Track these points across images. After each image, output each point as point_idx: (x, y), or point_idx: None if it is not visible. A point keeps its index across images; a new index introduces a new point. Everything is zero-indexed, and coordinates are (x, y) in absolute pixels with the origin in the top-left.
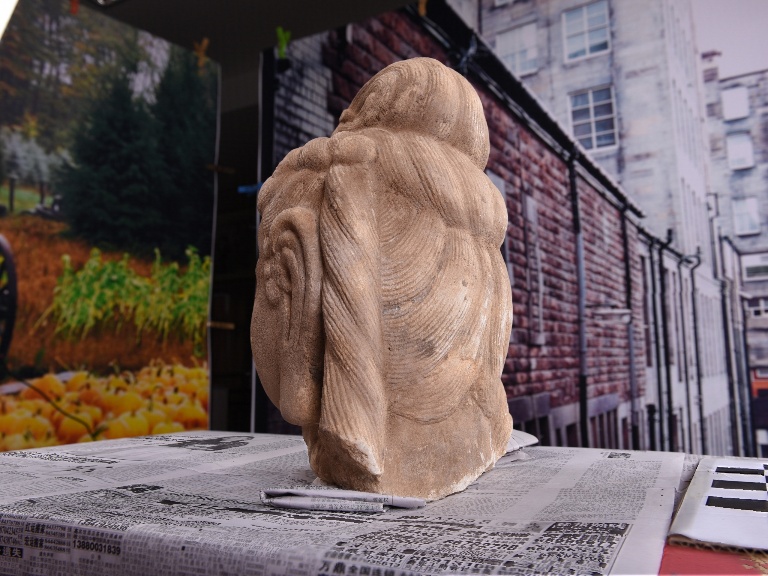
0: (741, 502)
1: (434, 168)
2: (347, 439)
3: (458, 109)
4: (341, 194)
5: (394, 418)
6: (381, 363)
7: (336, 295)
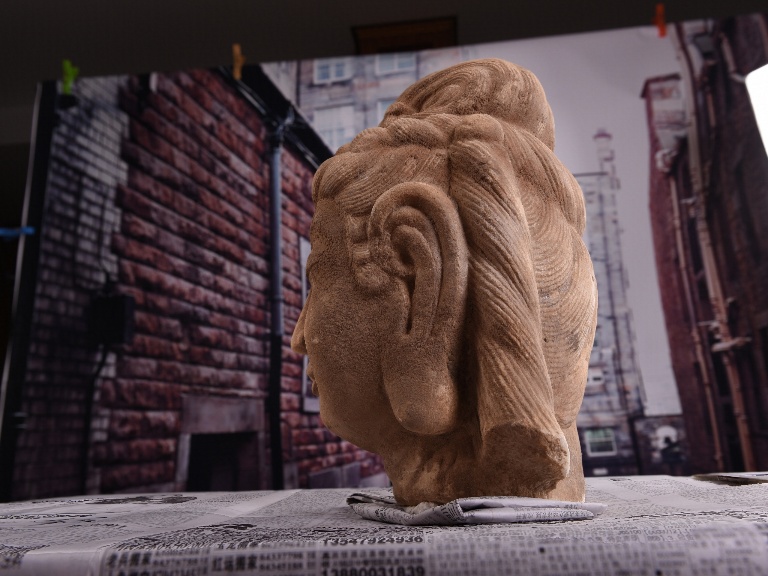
0: None
1: (555, 160)
2: (550, 433)
3: None
4: (496, 167)
5: None
6: None
7: (501, 274)
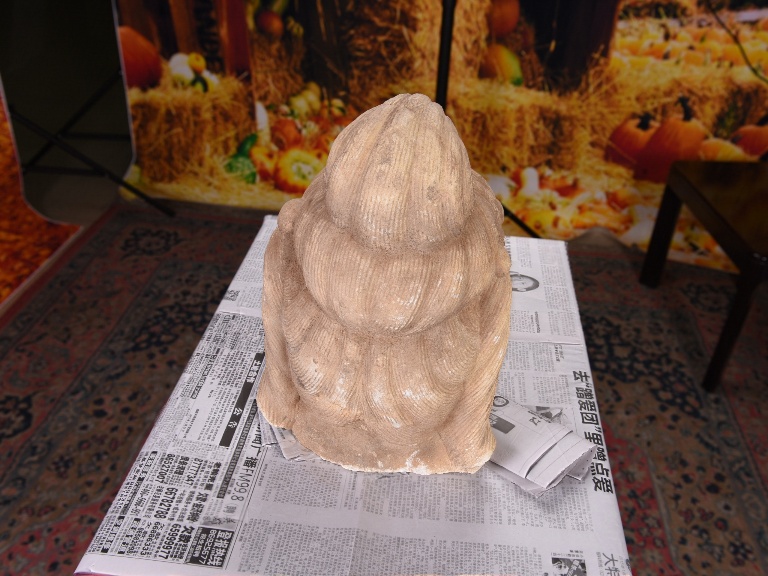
0: None
1: (306, 263)
2: None
3: (351, 206)
4: None
5: None
6: (287, 371)
7: None
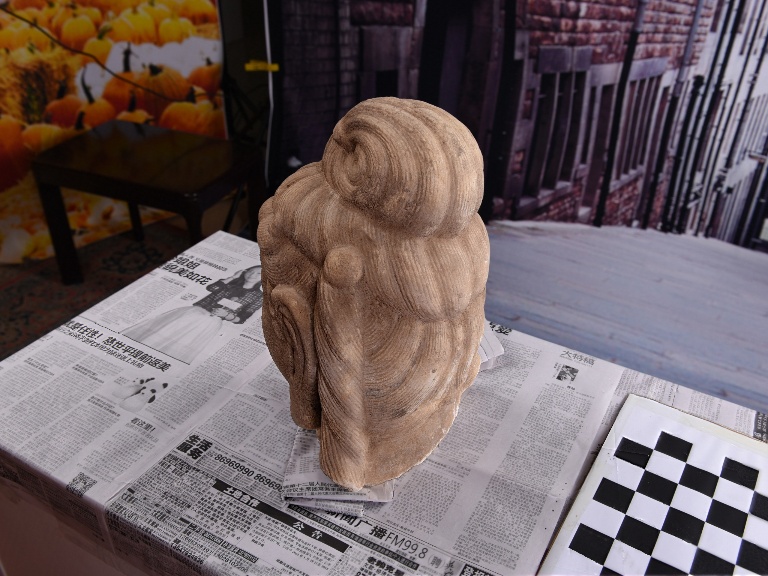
0: (596, 540)
1: (415, 287)
2: (338, 483)
3: (447, 206)
4: (330, 324)
5: (374, 443)
6: (364, 424)
7: (328, 391)
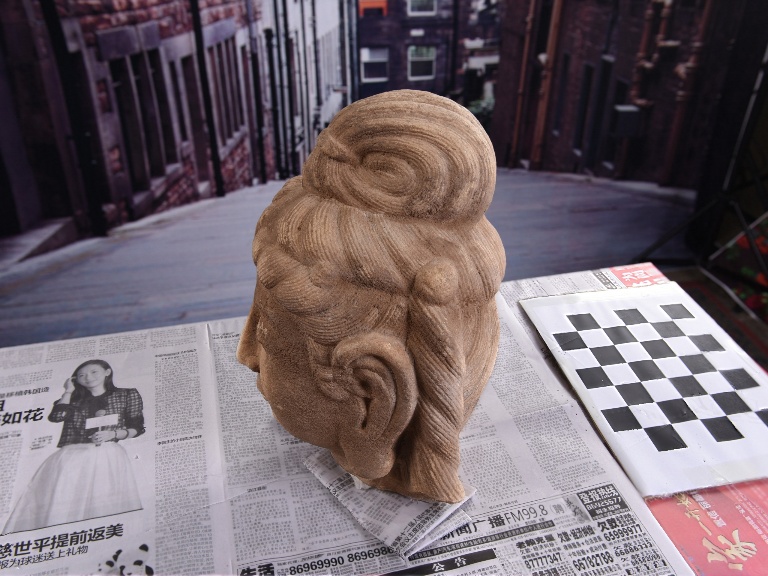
0: (621, 415)
1: None
2: None
3: None
4: (451, 344)
5: None
6: None
7: (442, 416)
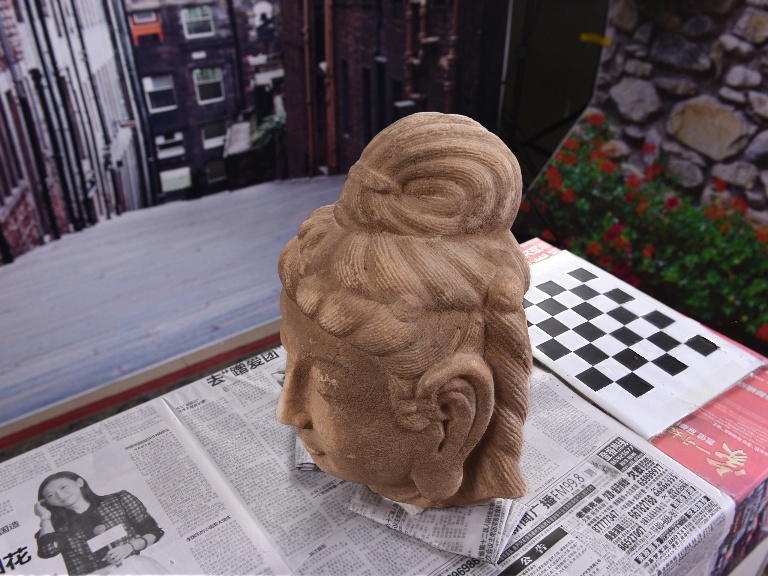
0: (592, 376)
1: None
2: None
3: None
4: None
5: None
6: None
7: (516, 416)
